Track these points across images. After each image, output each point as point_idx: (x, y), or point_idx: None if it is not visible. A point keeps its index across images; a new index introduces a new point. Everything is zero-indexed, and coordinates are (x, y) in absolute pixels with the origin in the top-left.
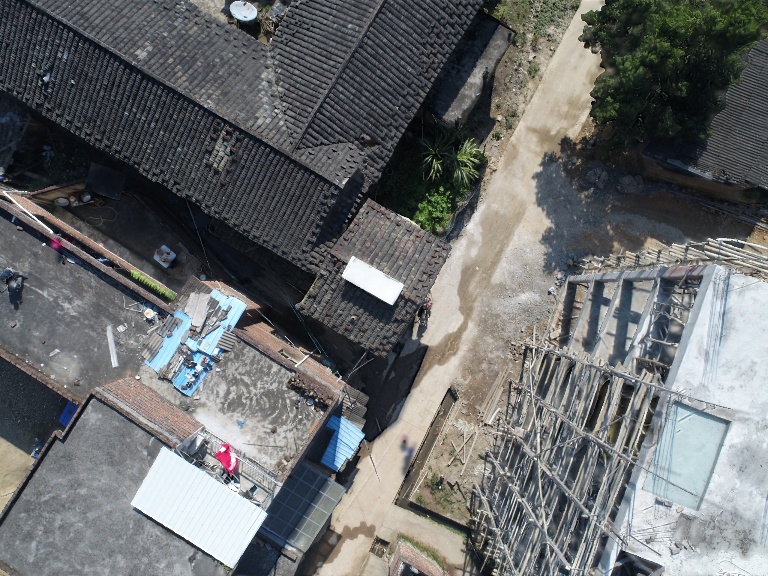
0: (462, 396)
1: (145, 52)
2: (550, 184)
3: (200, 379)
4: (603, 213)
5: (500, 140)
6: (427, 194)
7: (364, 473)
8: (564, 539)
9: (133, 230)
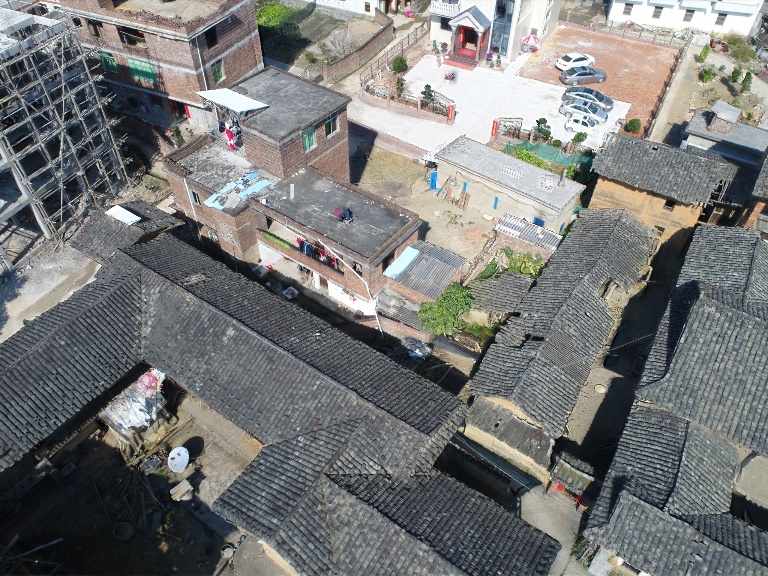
0: None
1: (228, 334)
2: None
3: None
4: None
5: None
6: None
7: None
8: None
9: None
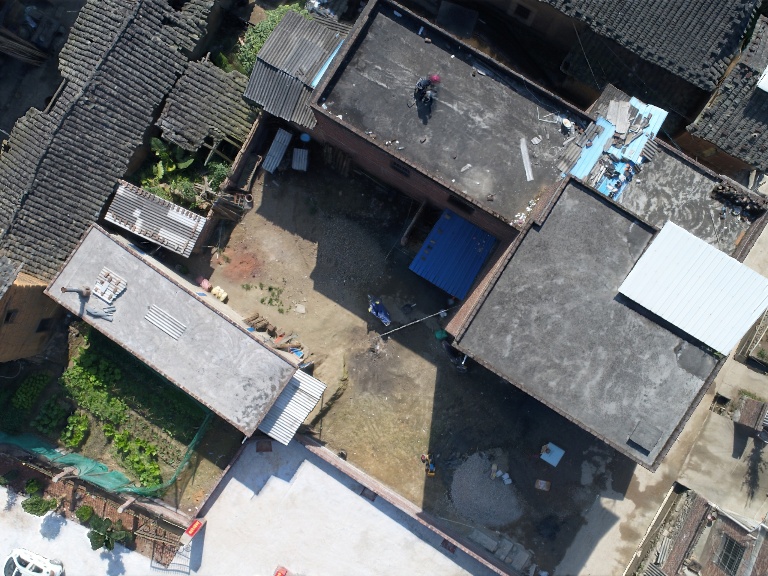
0: None
1: None
2: None
3: (620, 190)
4: None
5: None
6: None
7: None
8: None
9: None
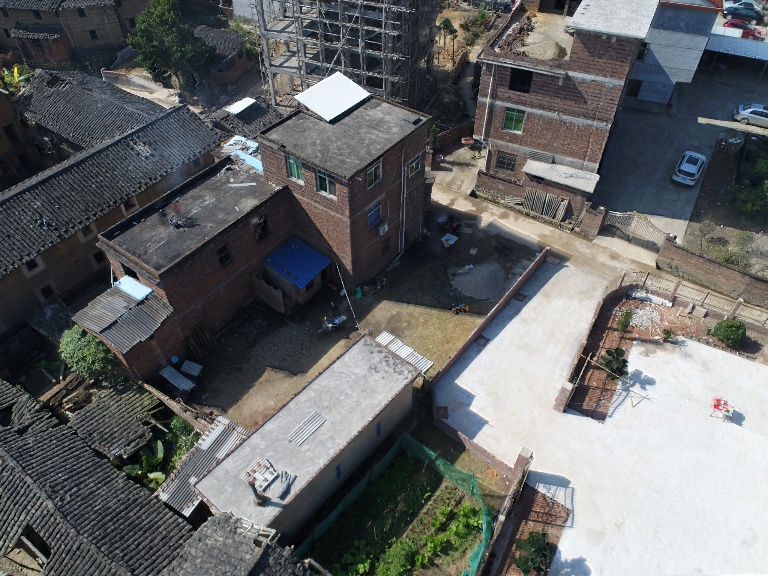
0: None
1: None
2: None
3: None
4: None
5: None
6: None
7: None
8: None
9: None
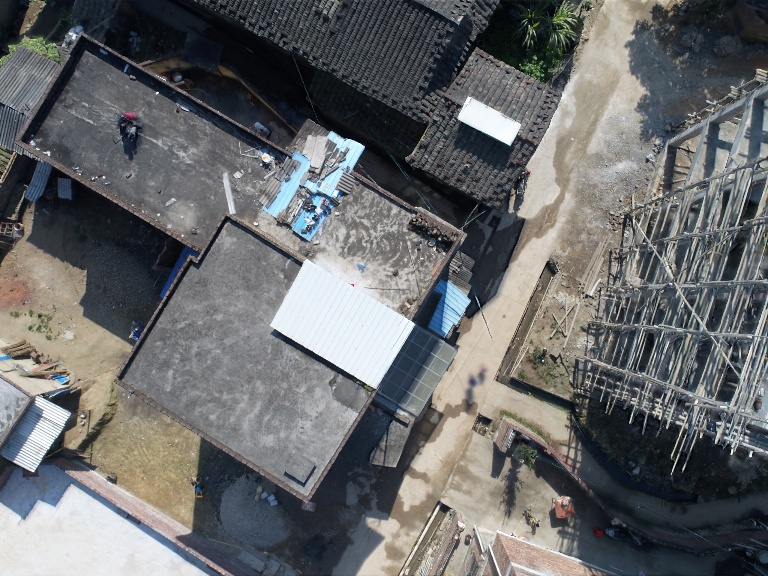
0: (561, 268)
1: None
2: (643, 52)
3: (319, 223)
4: (699, 78)
5: (590, 10)
6: (520, 64)
7: (464, 350)
8: (728, 330)
9: (223, 111)
